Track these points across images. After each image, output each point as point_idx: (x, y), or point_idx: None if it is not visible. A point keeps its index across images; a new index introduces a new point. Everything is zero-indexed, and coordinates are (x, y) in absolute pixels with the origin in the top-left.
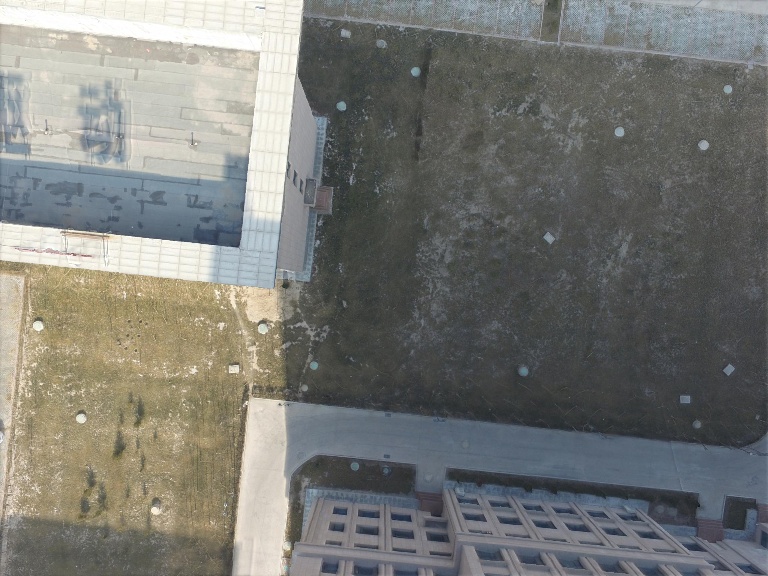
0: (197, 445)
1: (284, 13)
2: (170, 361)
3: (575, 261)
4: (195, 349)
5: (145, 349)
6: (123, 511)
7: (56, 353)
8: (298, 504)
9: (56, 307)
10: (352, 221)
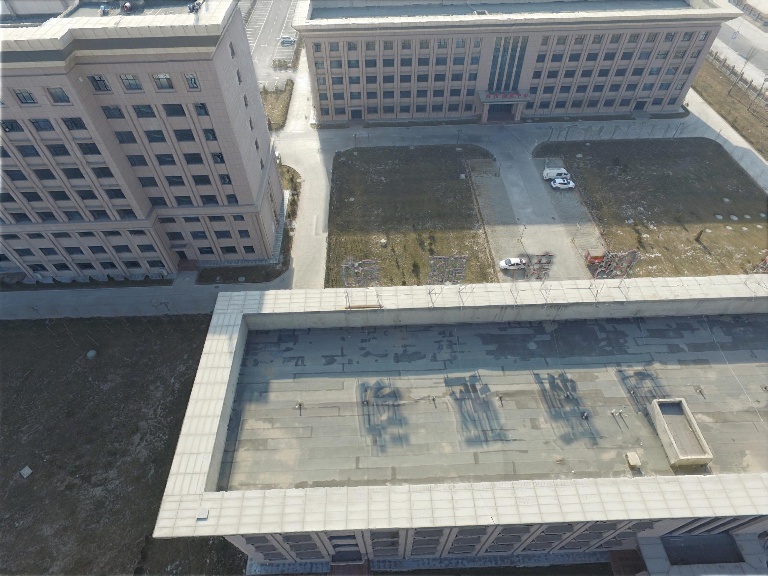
0: None
1: (177, 518)
2: None
3: (8, 453)
4: None
5: None
6: (406, 239)
7: None
8: (284, 255)
9: None
10: None
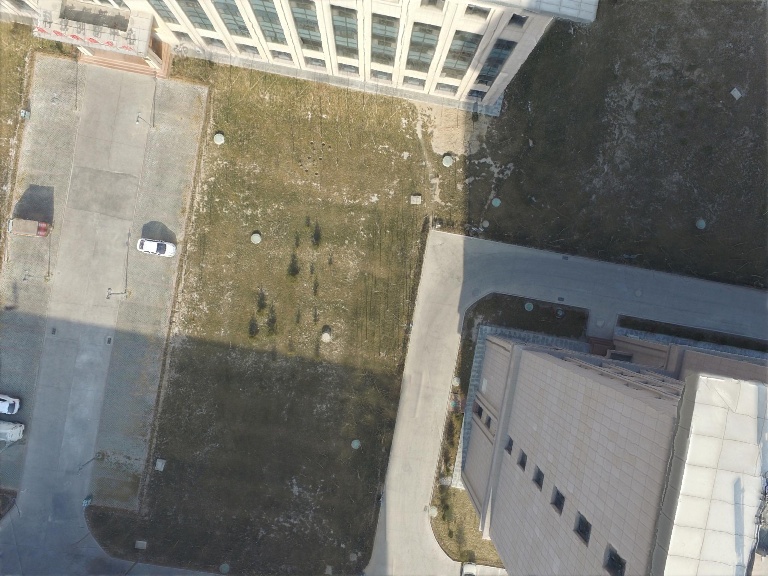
0: (372, 274)
1: None
2: (351, 187)
3: (758, 119)
4: (377, 177)
5: (326, 173)
6: (292, 336)
7: (235, 169)
8: (470, 341)
9: (238, 122)
10: (544, 60)
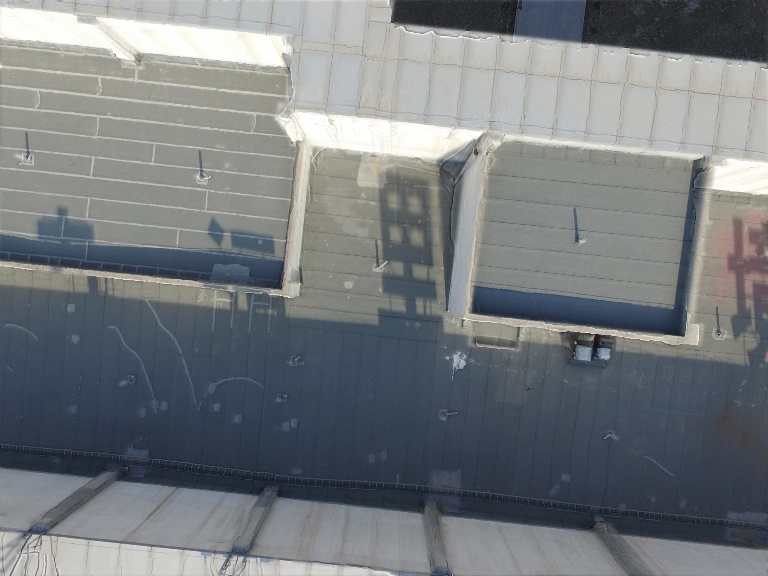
0: None
1: None
2: None
3: None
4: None
5: None
6: None
7: None
8: None
9: None
10: None
